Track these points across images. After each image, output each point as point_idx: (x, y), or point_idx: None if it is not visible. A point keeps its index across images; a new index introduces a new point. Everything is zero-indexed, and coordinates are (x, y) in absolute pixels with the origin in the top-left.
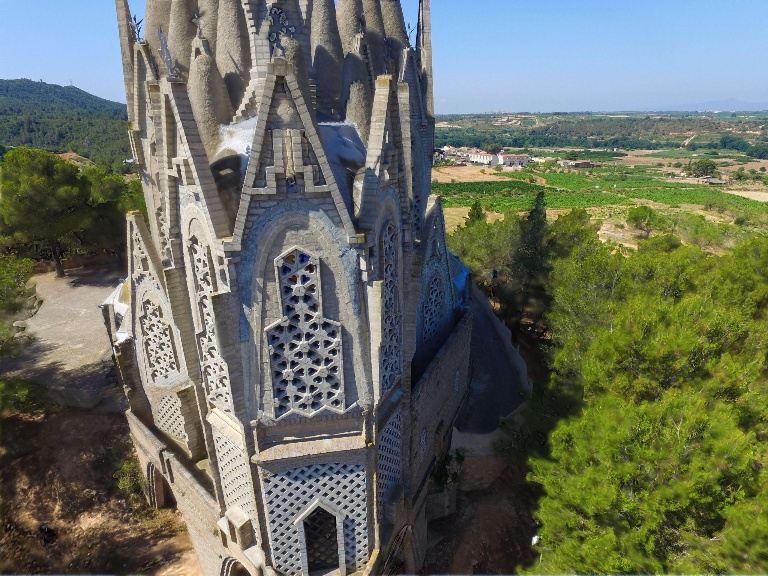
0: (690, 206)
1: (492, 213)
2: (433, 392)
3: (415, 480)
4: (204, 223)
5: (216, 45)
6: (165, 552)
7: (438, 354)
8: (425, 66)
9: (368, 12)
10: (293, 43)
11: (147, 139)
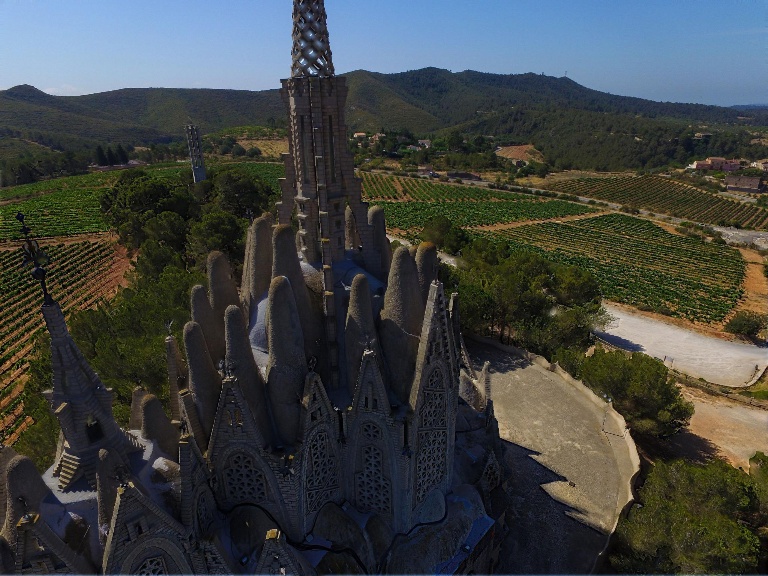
0: None
1: None
2: None
3: None
4: None
5: None
6: None
7: None
8: (417, 358)
9: (351, 302)
10: (10, 467)
11: None
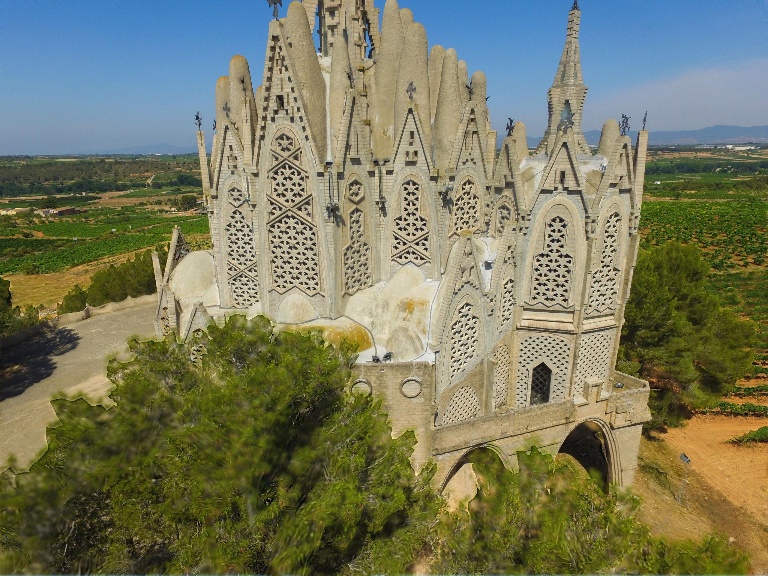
0: None
1: (41, 275)
2: None
3: None
4: (621, 204)
5: (445, 105)
6: None
7: None
8: None
9: None
10: None
11: (344, 180)
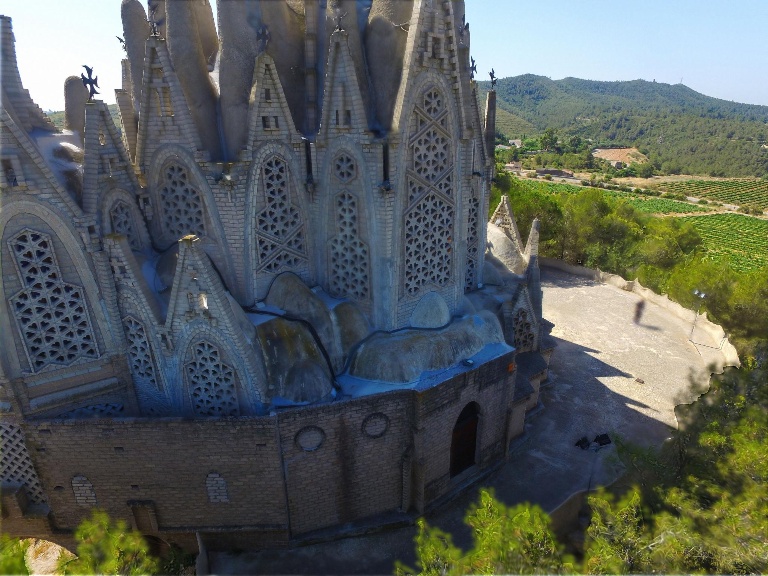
0: None
1: None
2: (102, 451)
3: (70, 515)
4: None
5: None
6: None
7: (120, 418)
8: (405, 51)
9: None
10: None
11: None
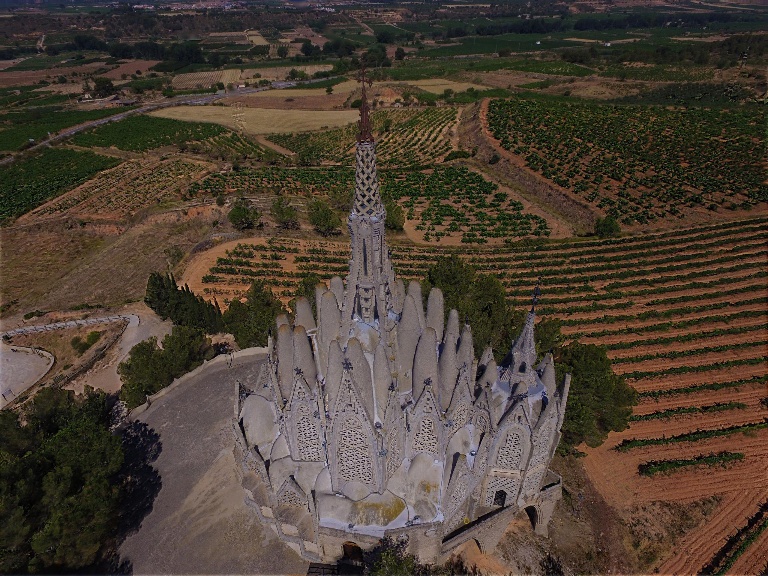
0: (166, 151)
1: None
2: None
3: None
4: None
5: (447, 368)
6: (462, 574)
7: None
8: None
9: None
10: None
11: None
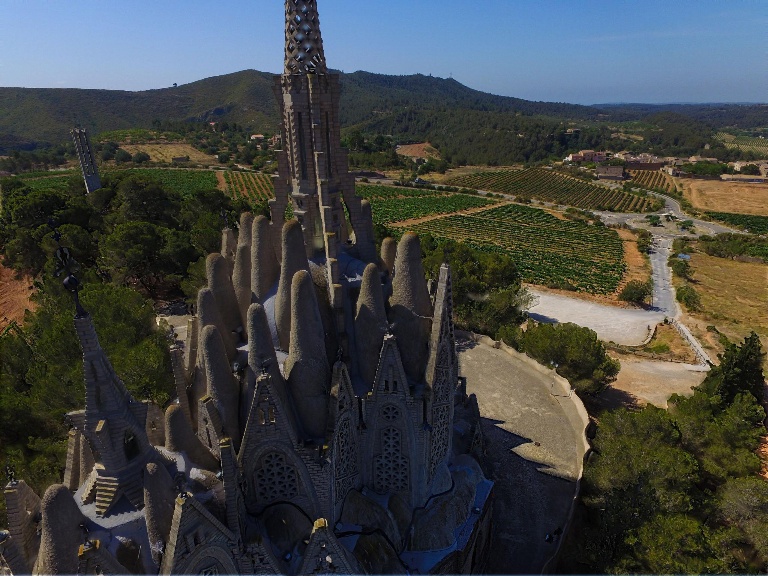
0: None
1: None
2: None
3: None
4: None
5: None
6: None
7: None
8: (431, 338)
9: (363, 291)
10: (49, 497)
11: None
